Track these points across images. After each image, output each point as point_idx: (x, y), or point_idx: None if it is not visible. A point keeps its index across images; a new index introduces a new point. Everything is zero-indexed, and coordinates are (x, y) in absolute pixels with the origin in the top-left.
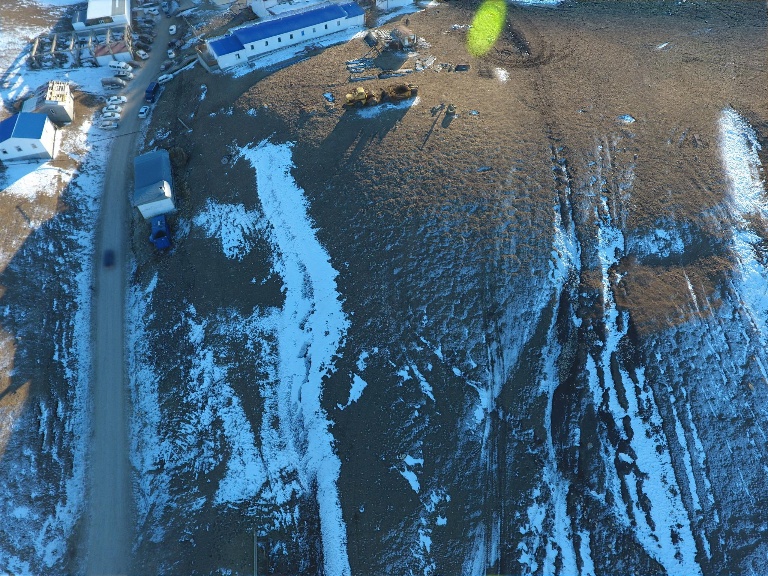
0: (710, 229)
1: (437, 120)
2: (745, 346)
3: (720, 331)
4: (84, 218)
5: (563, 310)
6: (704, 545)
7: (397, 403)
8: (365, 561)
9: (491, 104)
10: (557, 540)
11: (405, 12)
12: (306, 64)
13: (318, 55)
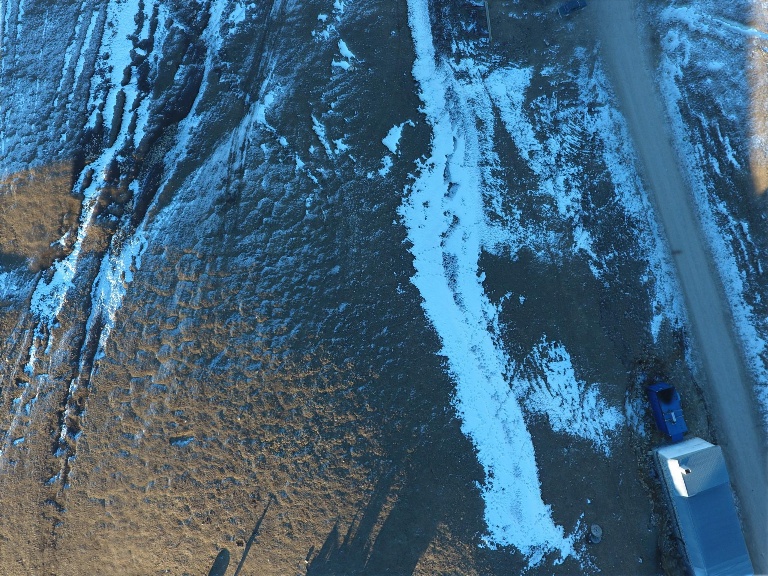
0: None
1: (235, 574)
2: None
3: None
4: None
5: (146, 201)
6: None
7: (352, 117)
8: None
9: None
10: None
11: None
12: None
13: None
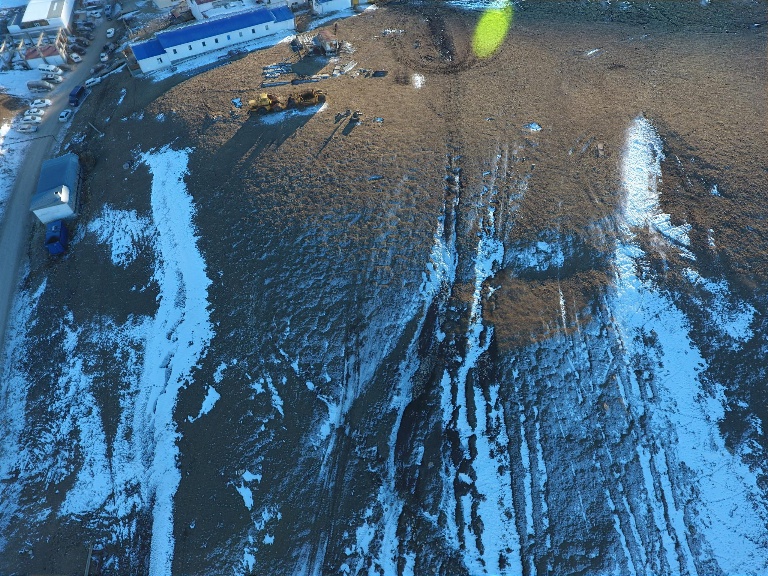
0: (593, 242)
1: (339, 127)
2: (607, 364)
3: (584, 348)
4: None
5: (428, 324)
6: (531, 571)
7: (245, 417)
8: None
9: (398, 111)
10: (381, 562)
11: (339, 16)
12: (225, 69)
13: (239, 60)
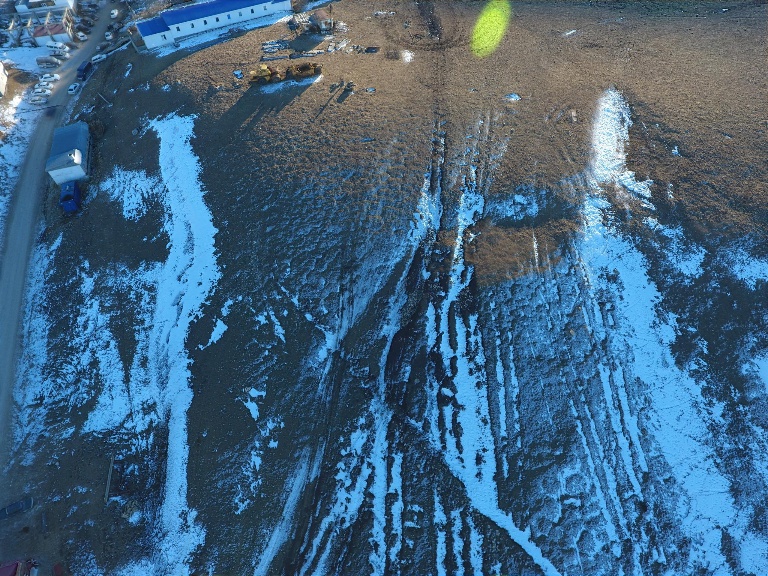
0: (565, 195)
1: (334, 96)
2: (574, 297)
3: (554, 284)
4: (2, 184)
5: (415, 264)
6: (503, 466)
7: (251, 344)
8: (200, 478)
9: (389, 82)
10: (373, 461)
11: None
12: (226, 45)
13: (239, 37)
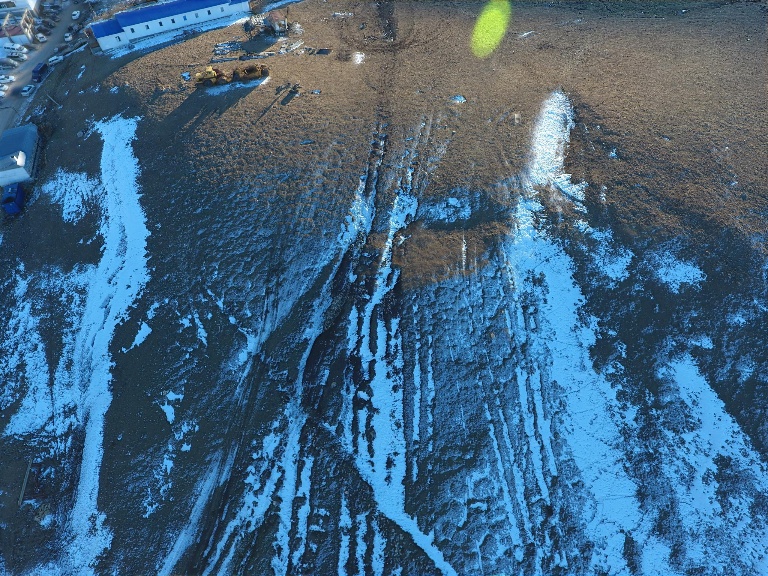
0: (498, 198)
1: (279, 98)
2: (498, 301)
3: (479, 287)
4: None
5: (342, 267)
6: (413, 470)
7: (173, 347)
8: (112, 481)
9: (335, 84)
10: (284, 464)
11: (294, 0)
12: (178, 46)
13: (193, 38)
